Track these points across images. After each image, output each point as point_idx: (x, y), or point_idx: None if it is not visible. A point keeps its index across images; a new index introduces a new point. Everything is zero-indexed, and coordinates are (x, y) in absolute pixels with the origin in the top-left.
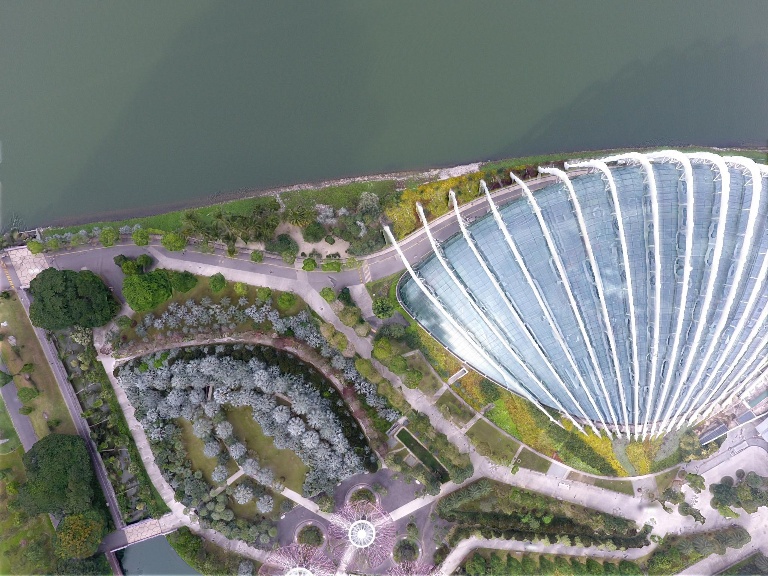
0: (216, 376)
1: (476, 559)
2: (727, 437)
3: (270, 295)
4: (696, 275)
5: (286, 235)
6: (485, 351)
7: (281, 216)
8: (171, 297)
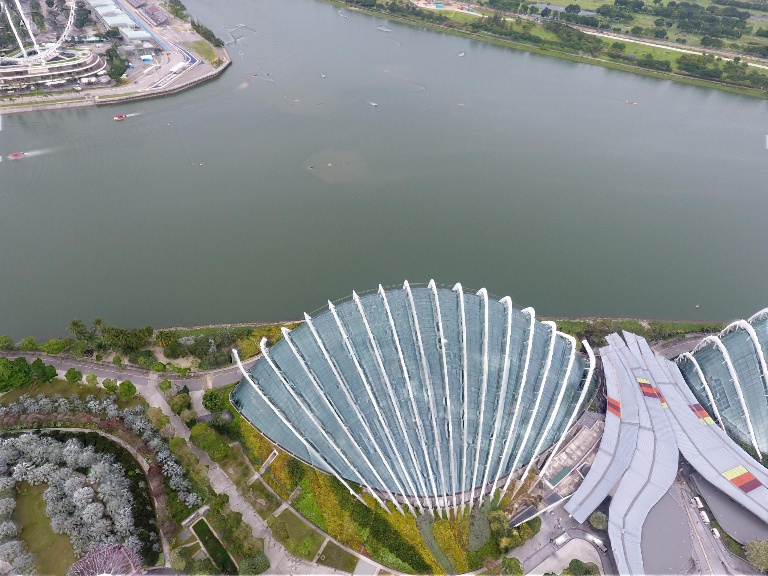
0: (28, 449)
1: None
2: (545, 527)
3: (117, 394)
4: (454, 349)
5: (150, 350)
6: (293, 427)
7: (153, 343)
8: (27, 393)
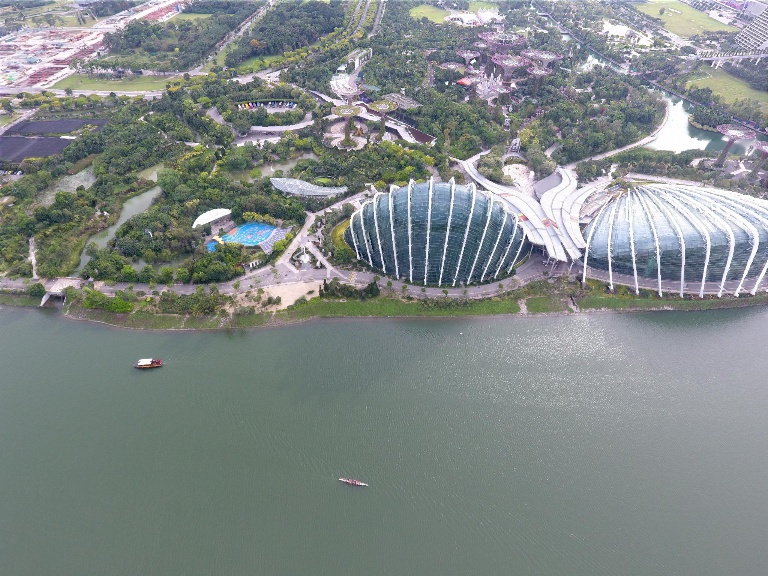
0: None
1: None
2: None
3: None
4: None
5: None
6: None
7: None
8: None
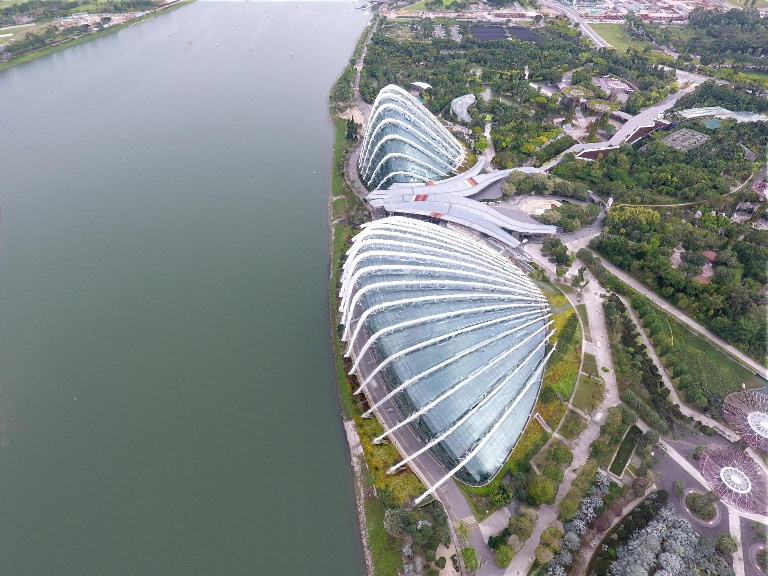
0: None
1: (692, 398)
2: None
3: None
4: None
5: None
6: None
7: None
8: None
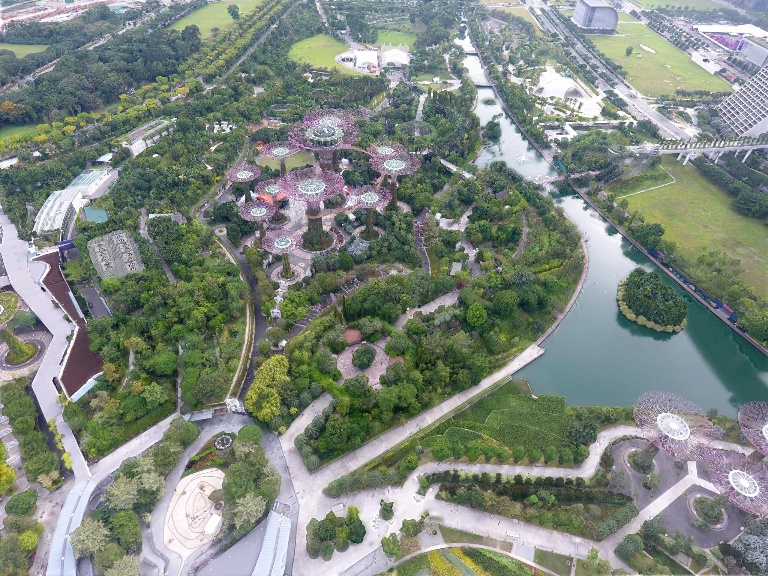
0: None
1: None
2: None
3: None
4: None
5: None
6: None
7: None
8: None
